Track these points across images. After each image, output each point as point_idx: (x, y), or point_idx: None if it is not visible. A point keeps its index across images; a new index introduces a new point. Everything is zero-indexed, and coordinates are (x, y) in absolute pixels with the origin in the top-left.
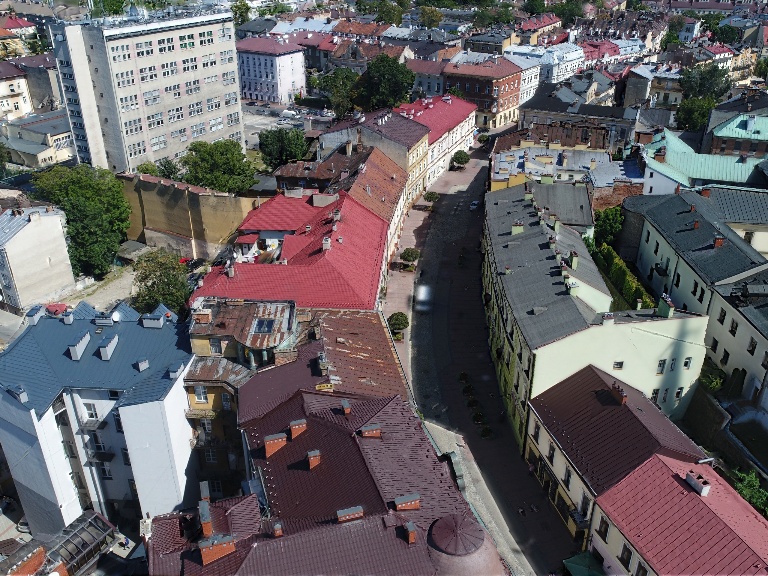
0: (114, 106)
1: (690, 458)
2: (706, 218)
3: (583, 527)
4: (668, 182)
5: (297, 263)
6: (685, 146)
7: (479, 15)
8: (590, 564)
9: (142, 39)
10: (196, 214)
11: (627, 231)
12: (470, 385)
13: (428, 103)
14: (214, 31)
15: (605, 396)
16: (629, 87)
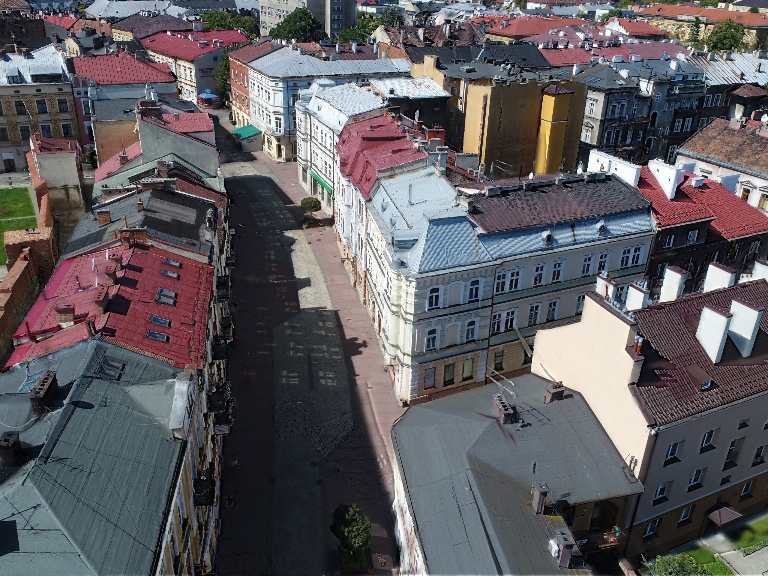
0: None
1: None
2: None
3: None
4: None
5: None
6: None
7: None
8: None
9: None
10: None
11: None
12: None
13: None
14: None
15: None
16: None
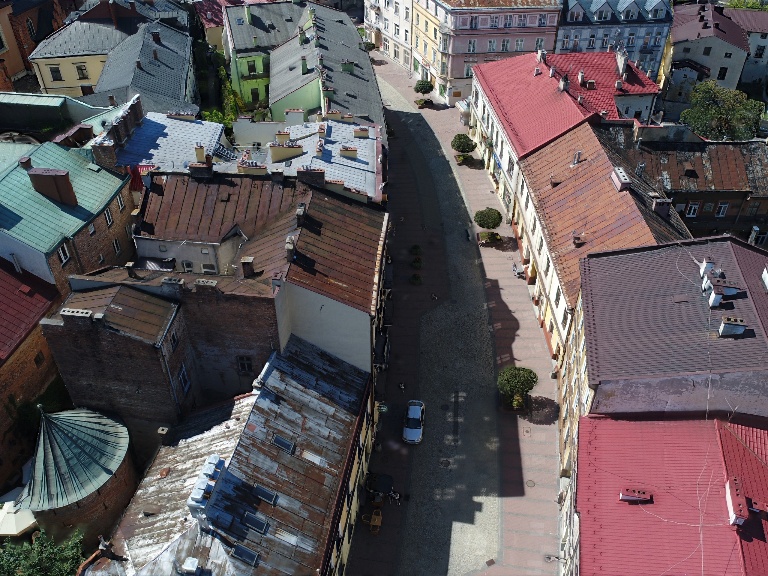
0: None
1: None
2: None
3: None
4: None
5: None
6: None
7: None
8: None
9: None
10: None
11: None
12: None
13: None
14: None
15: None
16: None
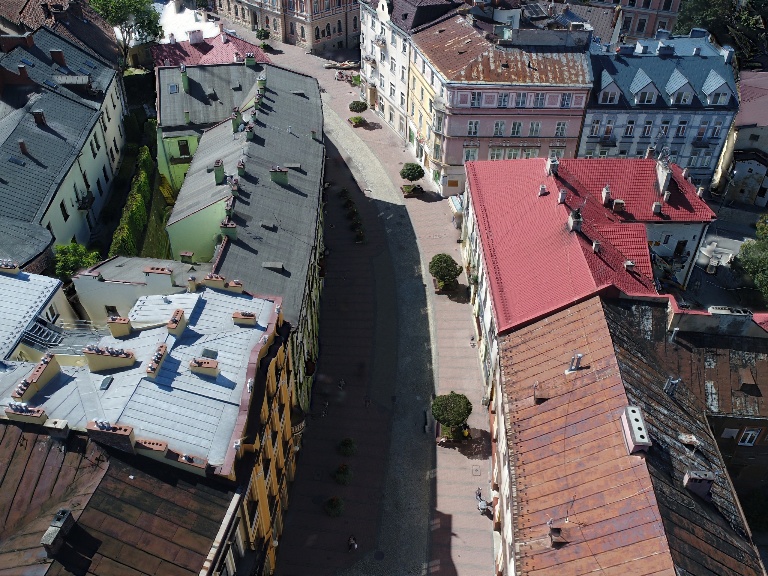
0: None
1: None
2: None
3: None
4: None
5: None
6: None
7: None
8: None
9: None
10: None
11: None
12: (356, 221)
13: None
14: None
15: None
16: None
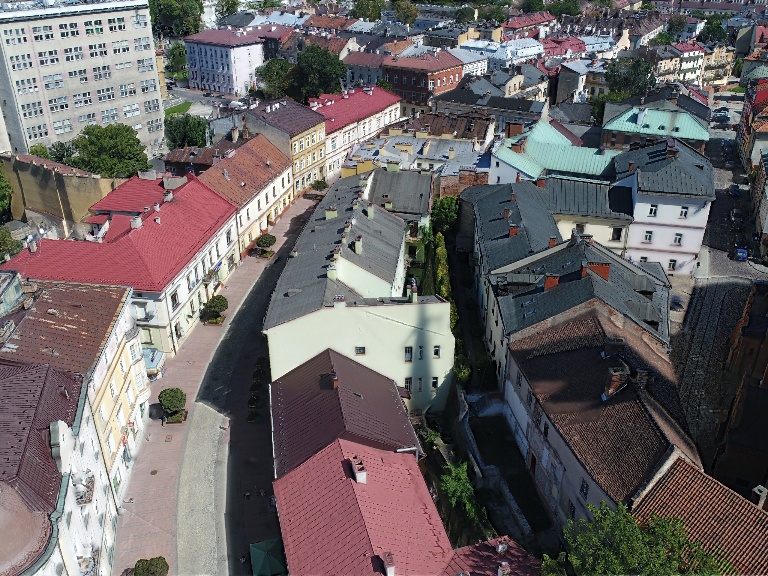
0: (9, 88)
1: (387, 446)
2: (521, 207)
3: (274, 511)
4: (514, 172)
5: (112, 242)
6: (561, 138)
7: (461, 11)
8: (271, 549)
9: (40, 23)
10: (63, 195)
11: (463, 221)
12: (260, 369)
13: (349, 94)
14: (126, 18)
15: (326, 380)
16: (561, 82)
